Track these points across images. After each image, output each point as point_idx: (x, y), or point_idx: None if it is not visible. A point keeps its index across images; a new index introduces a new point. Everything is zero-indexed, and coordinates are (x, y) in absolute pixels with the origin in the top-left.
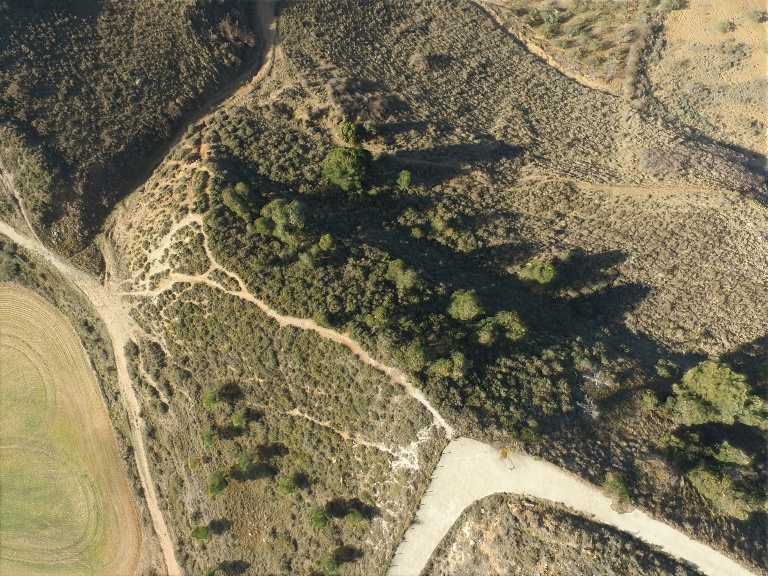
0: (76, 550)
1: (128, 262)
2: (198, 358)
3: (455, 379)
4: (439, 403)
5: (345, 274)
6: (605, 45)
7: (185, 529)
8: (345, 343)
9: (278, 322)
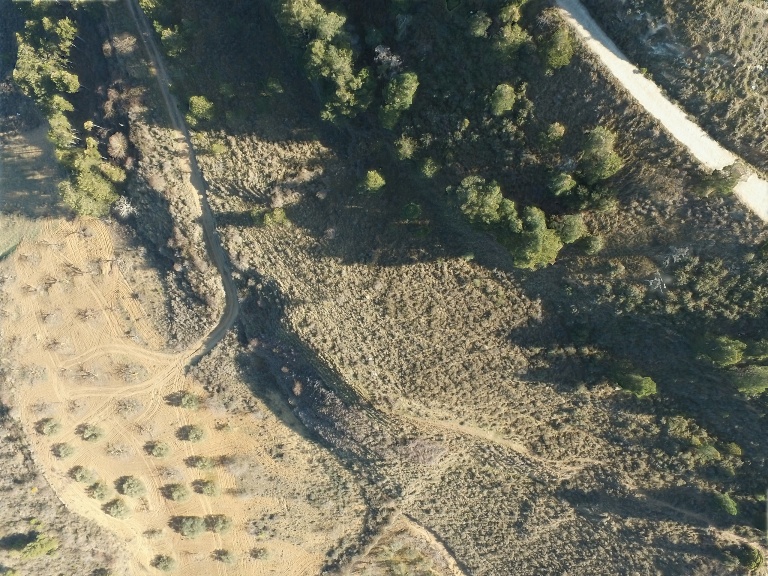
0: None
1: None
2: None
3: None
4: None
5: None
6: (387, 565)
7: None
8: None
9: None
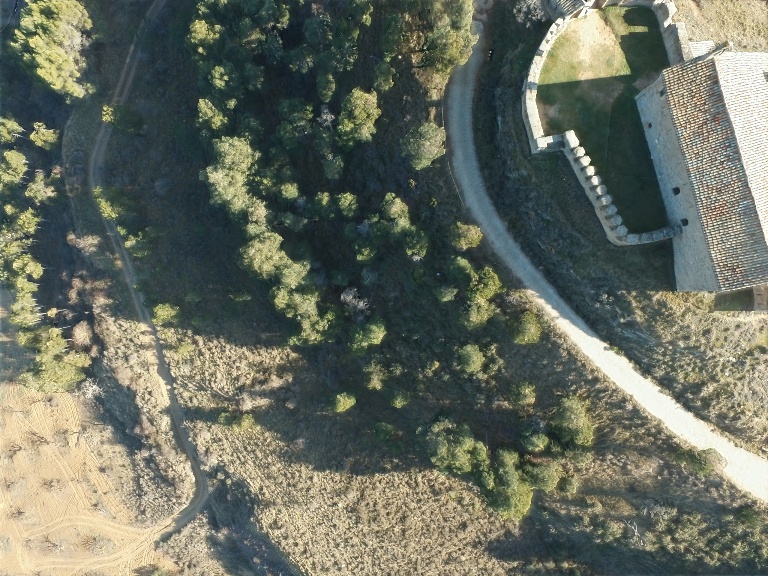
0: None
1: None
2: None
3: None
4: None
5: None
6: None
7: None
8: None
9: None
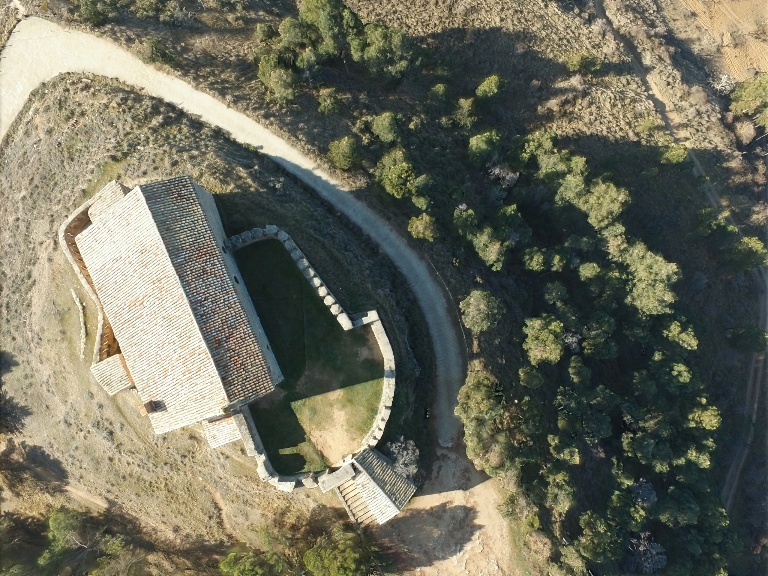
0: None
1: None
2: None
3: None
4: None
5: None
6: None
7: None
8: None
9: None
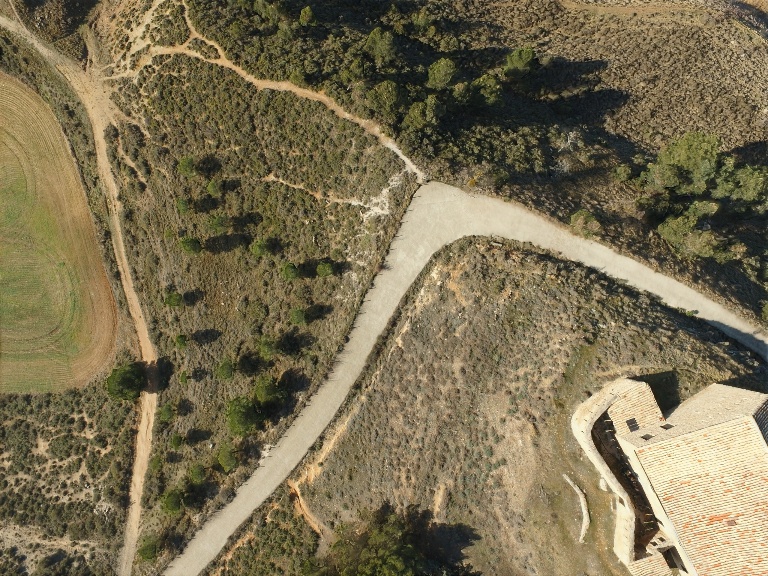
0: (52, 338)
1: (110, 47)
2: (176, 134)
3: (429, 133)
4: (411, 151)
5: (324, 47)
6: None
7: (159, 307)
8: (321, 101)
9: (255, 86)
